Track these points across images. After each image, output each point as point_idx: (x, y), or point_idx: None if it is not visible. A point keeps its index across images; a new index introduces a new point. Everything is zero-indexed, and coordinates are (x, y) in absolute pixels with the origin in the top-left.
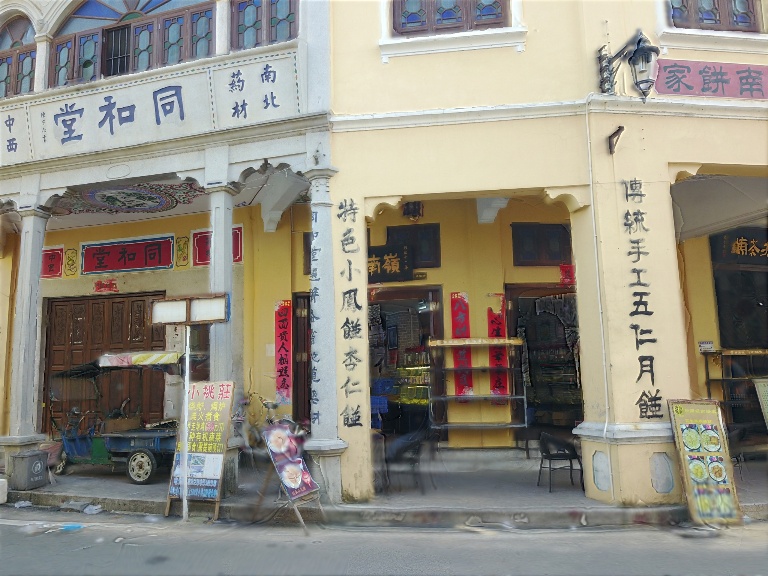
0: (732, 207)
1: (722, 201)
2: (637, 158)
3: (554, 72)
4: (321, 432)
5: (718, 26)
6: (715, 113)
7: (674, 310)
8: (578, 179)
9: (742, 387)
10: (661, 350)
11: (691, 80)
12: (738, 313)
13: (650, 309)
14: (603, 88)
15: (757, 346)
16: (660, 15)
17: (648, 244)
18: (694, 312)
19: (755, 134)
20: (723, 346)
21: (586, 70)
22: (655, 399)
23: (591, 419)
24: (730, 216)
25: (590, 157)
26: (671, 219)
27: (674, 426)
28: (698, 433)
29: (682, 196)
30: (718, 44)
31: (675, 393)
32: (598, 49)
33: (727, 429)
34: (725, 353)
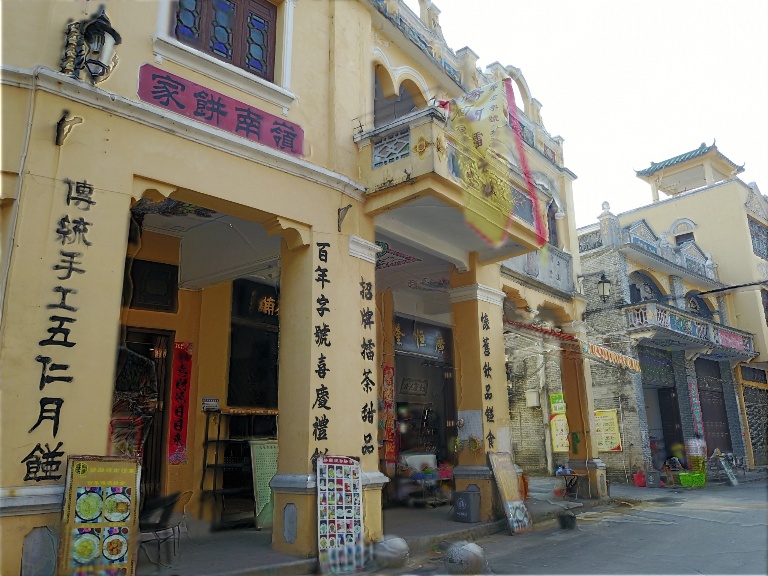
0: (239, 255)
1: (232, 248)
2: (93, 159)
3: (4, 31)
4: None
5: (228, 61)
6: (200, 138)
7: (105, 344)
8: (4, 164)
9: (237, 449)
10: (76, 392)
11: (183, 99)
12: (254, 372)
13: (71, 339)
14: (63, 67)
15: (264, 407)
16: (160, 22)
17: (86, 260)
18: (202, 366)
19: (241, 172)
20: (232, 405)
21: (47, 41)
22: (53, 455)
23: None
24: (237, 264)
25: (27, 141)
26: (124, 237)
27: (68, 490)
28: (101, 498)
29: (202, 239)
30: (219, 74)
31: (85, 447)
32: (68, 24)
33: (214, 496)
34: (224, 411)
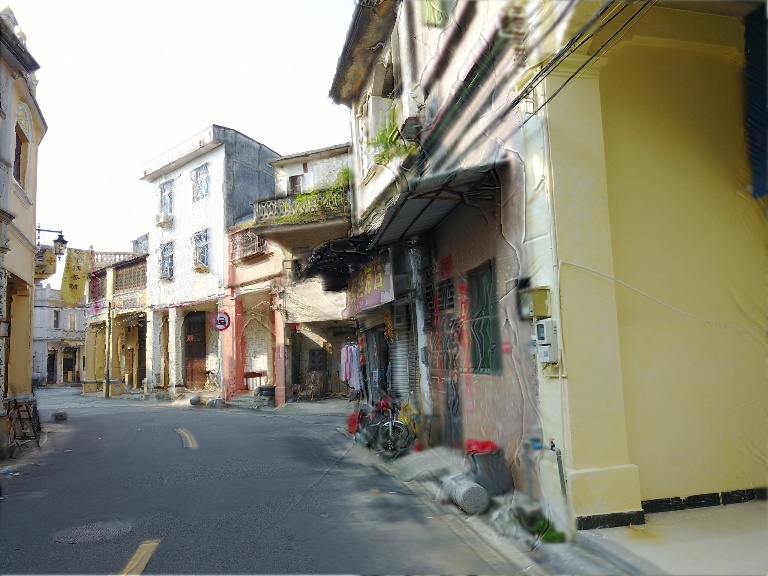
0: None
1: None
2: None
3: None
4: (0, 406)
5: None
6: None
7: None
8: None
9: None
10: None
11: None
12: None
13: None
14: None
15: None
16: None
17: None
18: None
19: None
20: None
21: None
22: None
23: (13, 395)
24: None
25: None
26: None
27: None
28: None
29: None
30: None
31: None
32: None
33: None
34: None
